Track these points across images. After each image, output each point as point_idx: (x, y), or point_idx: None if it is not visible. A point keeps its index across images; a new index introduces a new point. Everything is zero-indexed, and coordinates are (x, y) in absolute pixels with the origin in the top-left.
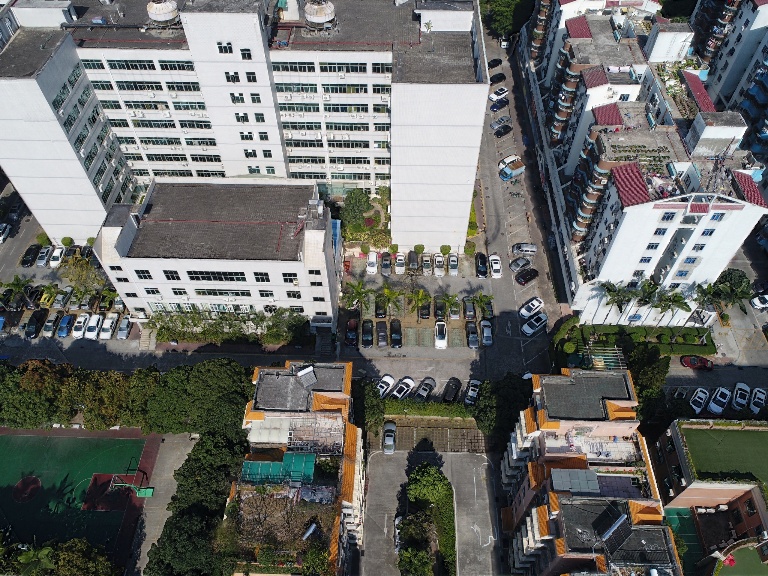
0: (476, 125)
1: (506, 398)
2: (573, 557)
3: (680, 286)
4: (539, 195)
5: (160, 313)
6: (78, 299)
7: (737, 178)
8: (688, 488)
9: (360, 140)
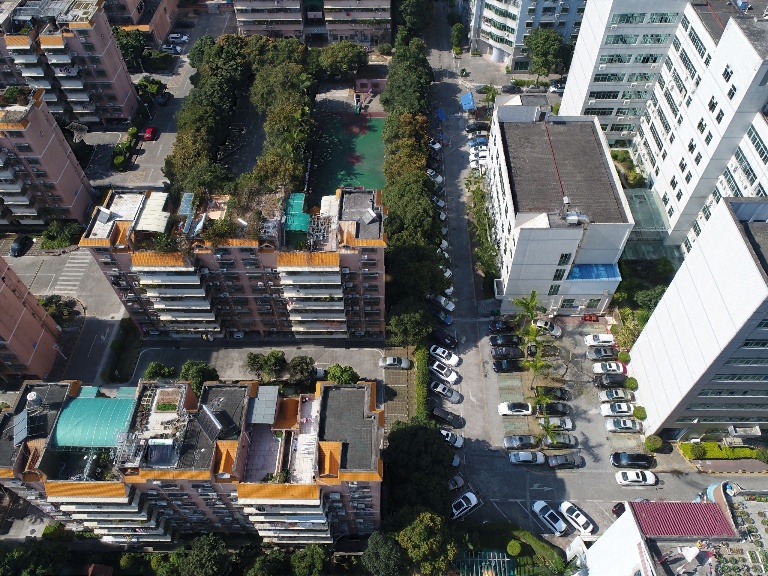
0: (735, 323)
1: None
2: None
3: None
4: None
5: None
6: None
7: None
8: None
9: None
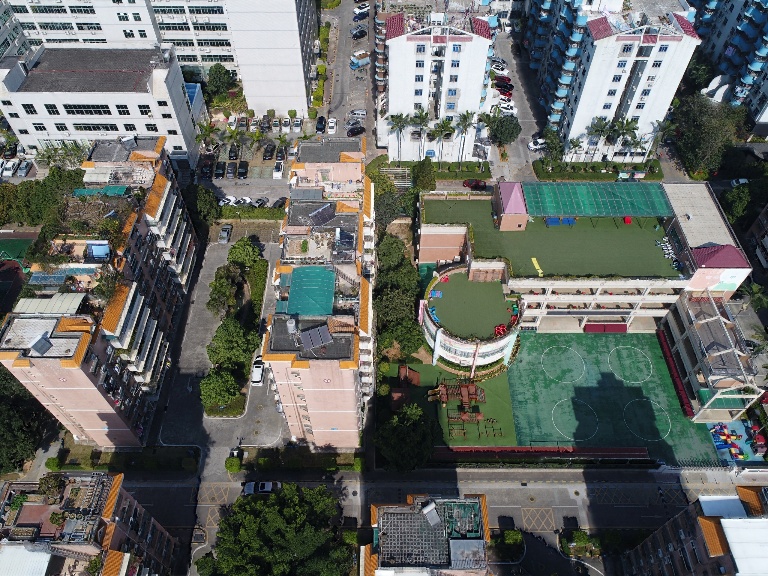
0: None
1: None
2: (294, 233)
3: (454, 119)
4: None
5: (48, 147)
6: None
7: (474, 21)
8: (422, 234)
9: (219, 23)
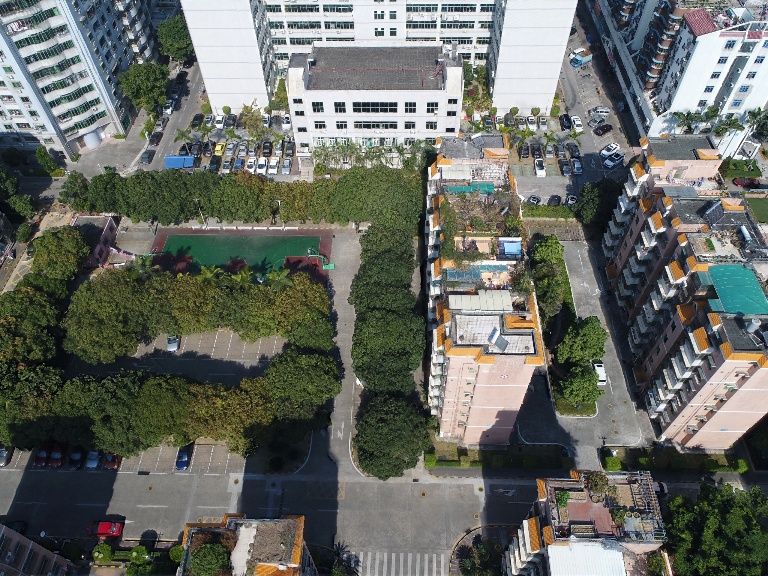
0: None
1: (605, 191)
2: (684, 231)
3: (734, 116)
4: (606, 76)
5: (323, 145)
6: (245, 148)
7: None
8: None
9: (467, 21)
